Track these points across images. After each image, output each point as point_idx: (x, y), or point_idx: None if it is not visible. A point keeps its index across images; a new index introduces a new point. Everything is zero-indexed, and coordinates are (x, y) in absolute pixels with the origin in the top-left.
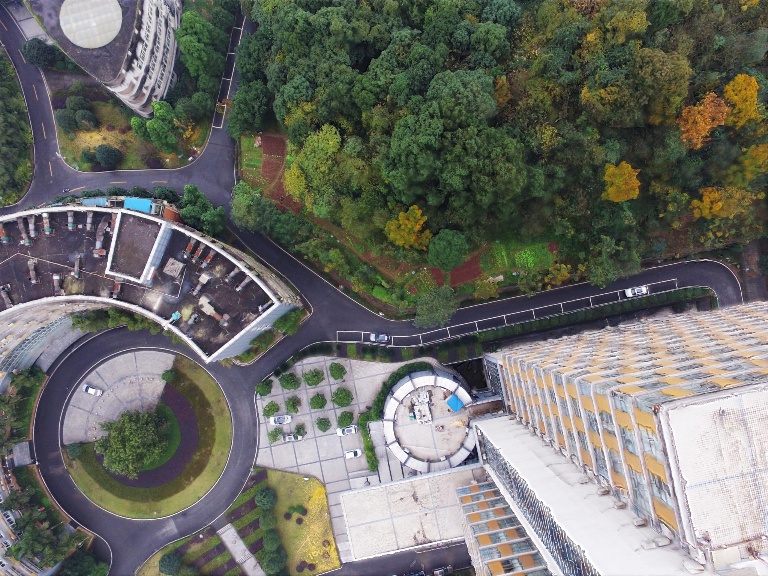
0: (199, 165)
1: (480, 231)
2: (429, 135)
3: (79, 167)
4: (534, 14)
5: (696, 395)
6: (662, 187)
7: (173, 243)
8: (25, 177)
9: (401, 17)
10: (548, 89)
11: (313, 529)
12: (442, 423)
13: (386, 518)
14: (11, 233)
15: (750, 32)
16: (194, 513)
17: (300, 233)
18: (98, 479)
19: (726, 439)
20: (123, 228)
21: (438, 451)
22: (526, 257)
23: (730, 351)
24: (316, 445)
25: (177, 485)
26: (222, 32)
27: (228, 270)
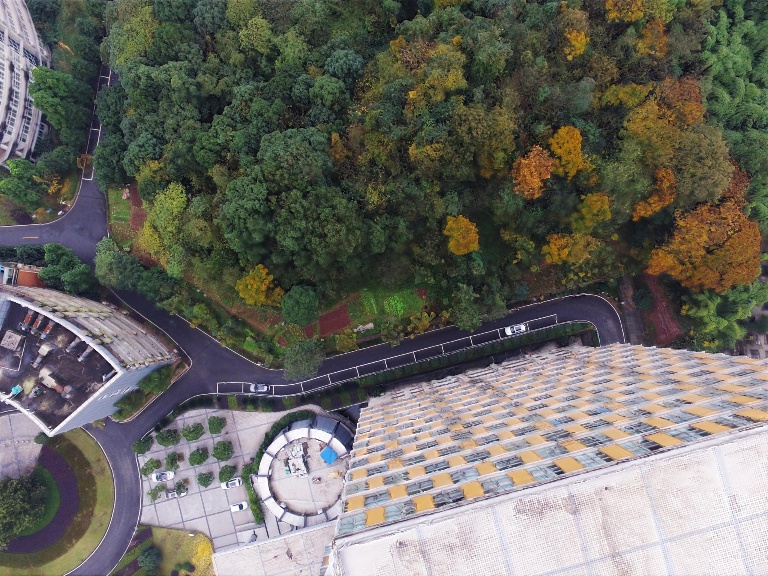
0: (70, 219)
1: (334, 285)
2: (253, 200)
3: None
4: (377, 64)
5: (369, 530)
6: (511, 234)
7: (12, 314)
8: None
9: (254, 67)
10: (384, 144)
11: None
12: (319, 475)
13: None
14: None
15: (577, 81)
16: None
17: (162, 290)
18: None
19: (403, 572)
20: None
21: (316, 504)
22: (395, 303)
23: (484, 444)
24: (201, 500)
25: (58, 549)
26: (82, 84)
27: (70, 340)
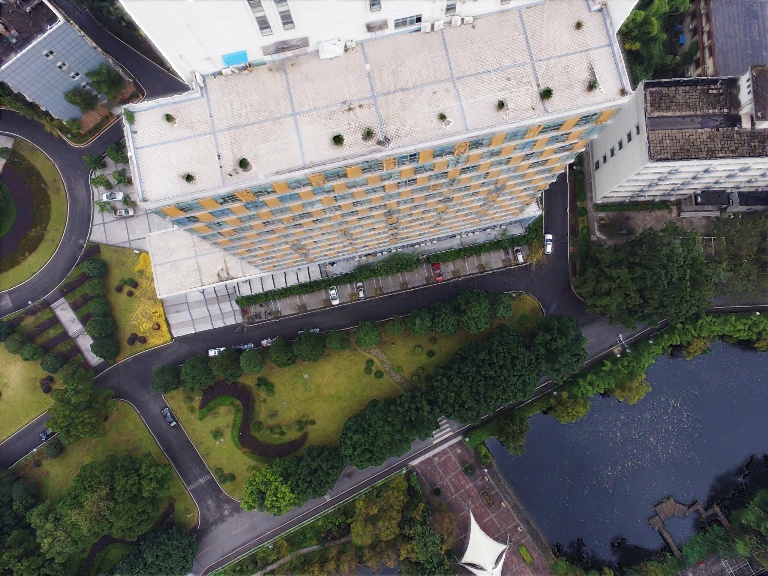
0: None
1: None
2: None
3: None
4: None
5: None
6: None
7: None
8: None
9: None
10: None
11: (143, 301)
12: None
13: (191, 256)
14: None
15: None
16: (29, 288)
17: None
18: None
19: None
20: None
21: None
22: None
23: None
24: (147, 221)
25: (12, 260)
26: None
27: None
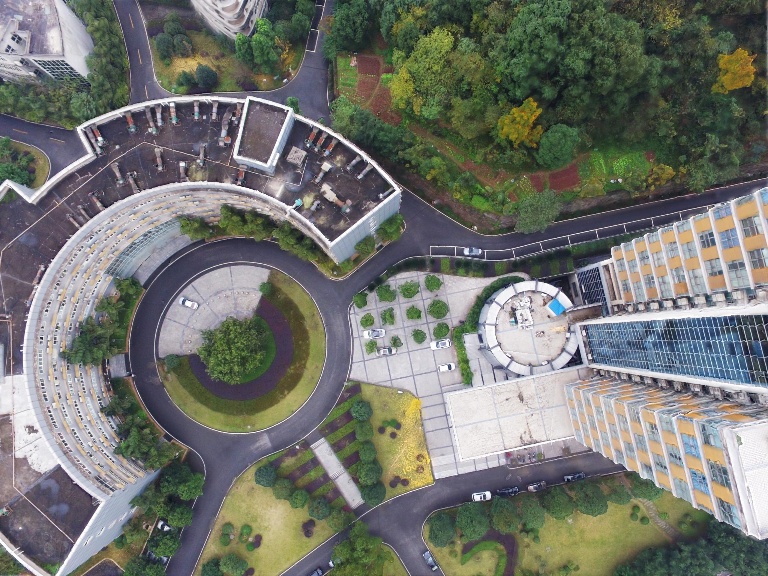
0: (293, 87)
1: (589, 128)
2: (557, 16)
3: (175, 90)
4: None
5: None
6: None
7: (295, 134)
8: (122, 99)
9: None
10: None
11: (407, 443)
12: (542, 329)
13: (492, 418)
14: (138, 123)
15: None
16: (288, 427)
17: (404, 140)
18: (193, 392)
19: None
20: (250, 115)
21: (539, 356)
22: (624, 165)
23: None
24: (409, 359)
25: (272, 398)
26: None
27: (349, 159)
